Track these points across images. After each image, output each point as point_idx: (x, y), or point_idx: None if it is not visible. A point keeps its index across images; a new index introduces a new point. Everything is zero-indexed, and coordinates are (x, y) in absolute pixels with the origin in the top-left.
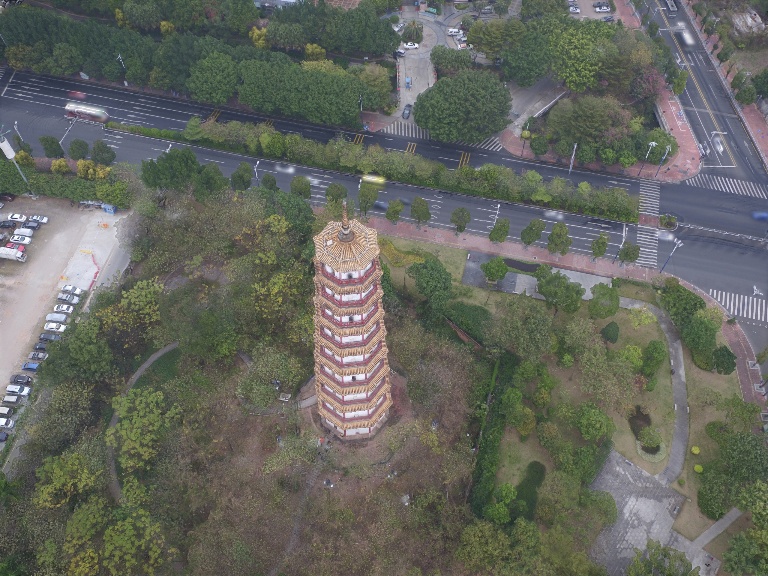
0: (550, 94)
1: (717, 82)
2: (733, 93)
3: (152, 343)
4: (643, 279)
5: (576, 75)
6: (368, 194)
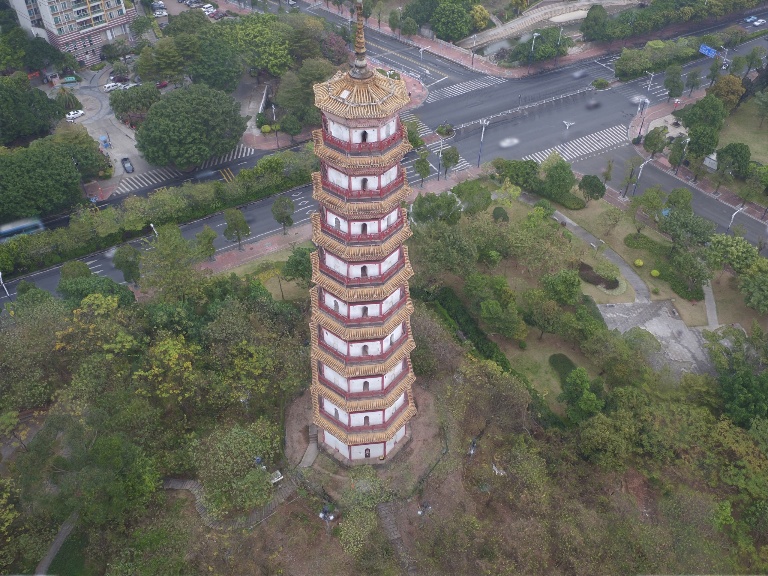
0: (254, 94)
1: (376, 34)
2: (395, 34)
3: (16, 571)
4: (471, 178)
5: (273, 58)
6: None
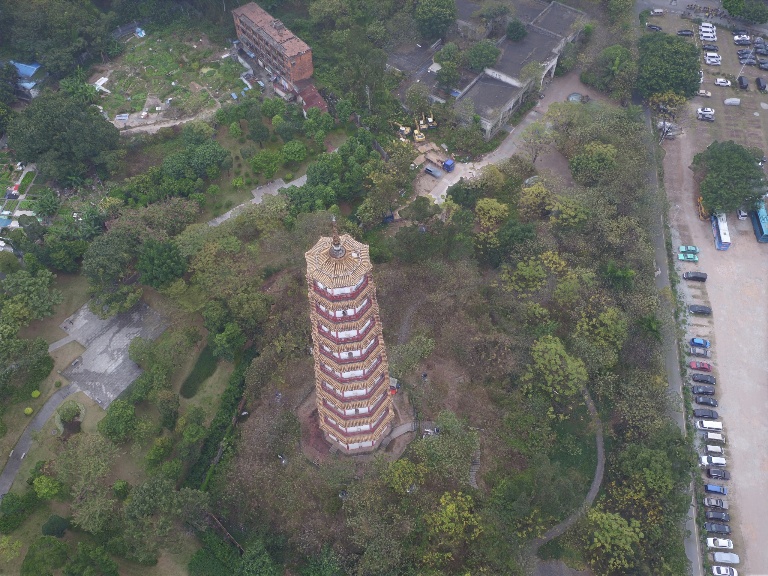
0: None
1: None
2: None
3: None
4: None
5: None
6: None
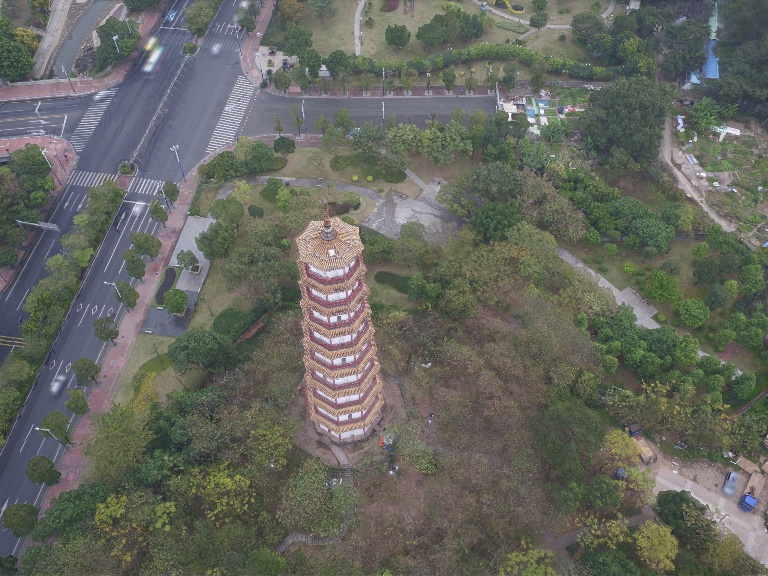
0: None
1: None
2: None
3: None
4: (191, 194)
5: None
6: (60, 420)
